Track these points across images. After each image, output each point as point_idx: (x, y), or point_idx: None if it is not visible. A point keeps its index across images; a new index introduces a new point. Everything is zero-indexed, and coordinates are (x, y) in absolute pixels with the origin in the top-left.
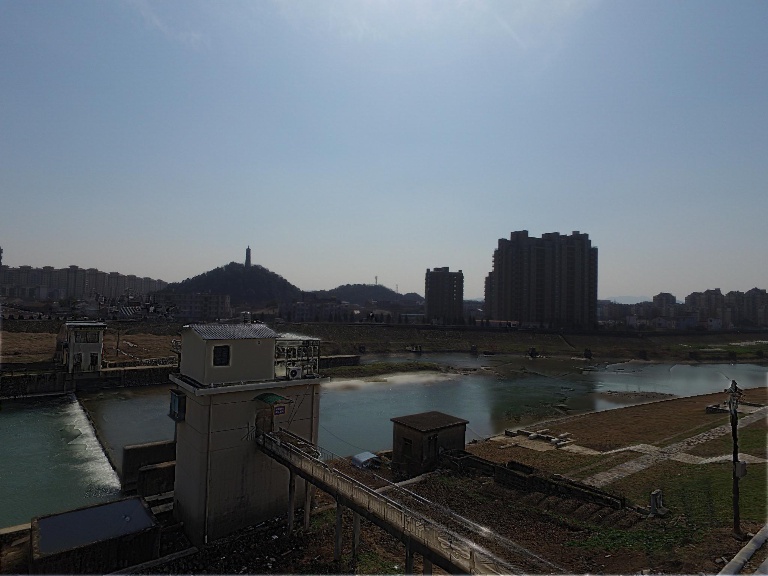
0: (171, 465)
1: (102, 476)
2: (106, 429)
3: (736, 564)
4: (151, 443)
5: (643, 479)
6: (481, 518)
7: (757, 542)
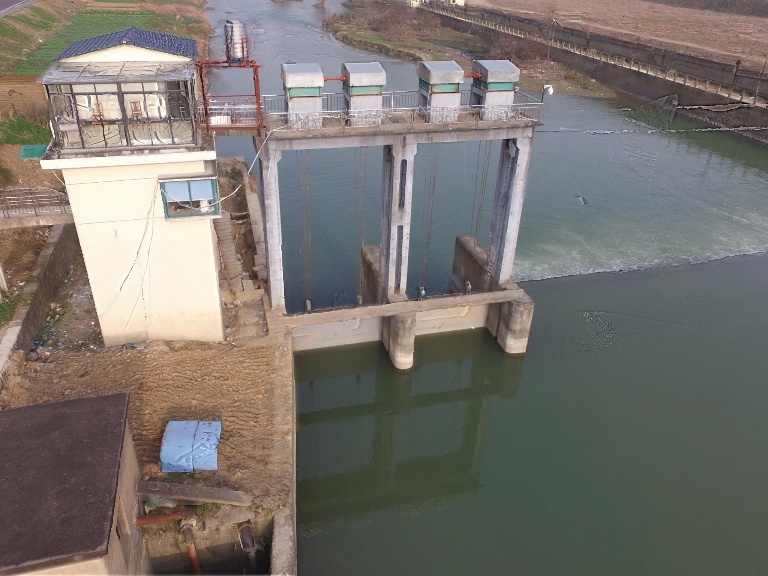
0: (370, 263)
1: (522, 276)
2: (765, 269)
3: None
4: (481, 251)
5: None
6: None
7: None
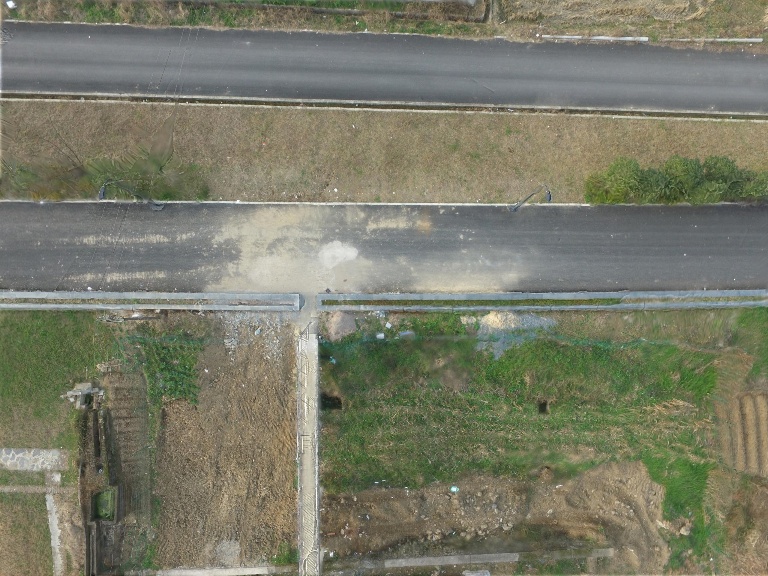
0: None
1: None
2: None
3: (205, 307)
4: None
5: (3, 432)
6: (190, 479)
7: (167, 306)
